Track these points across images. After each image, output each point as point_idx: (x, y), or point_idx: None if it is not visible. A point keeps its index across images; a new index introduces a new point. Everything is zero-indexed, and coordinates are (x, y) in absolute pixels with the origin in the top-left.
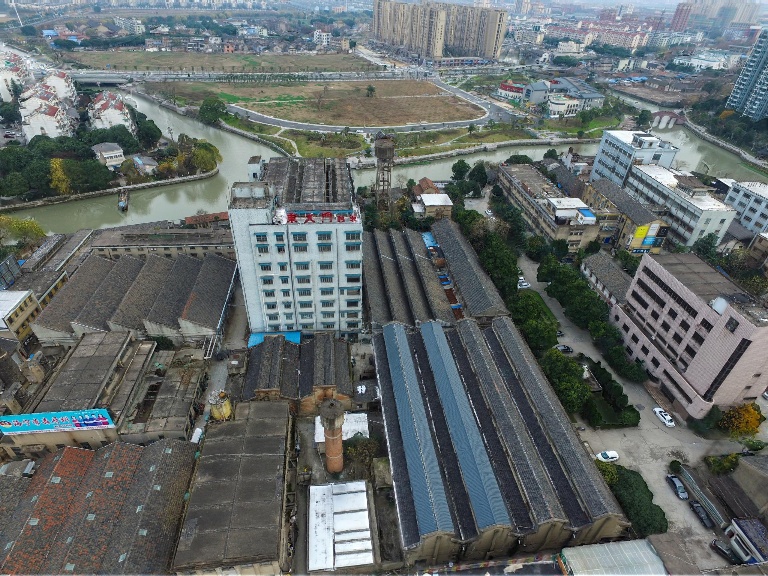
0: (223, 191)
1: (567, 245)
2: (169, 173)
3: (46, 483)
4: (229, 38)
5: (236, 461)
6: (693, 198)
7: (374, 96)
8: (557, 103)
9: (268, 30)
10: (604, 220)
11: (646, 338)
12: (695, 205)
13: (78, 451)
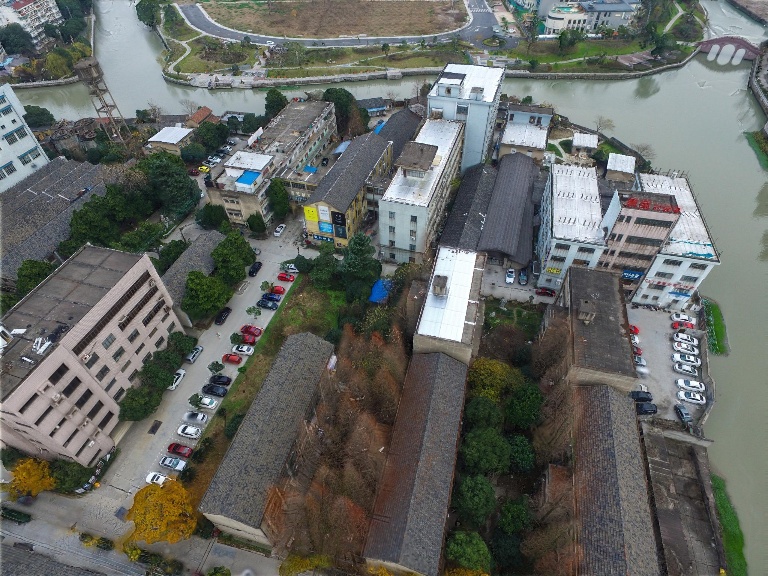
0: None
1: (219, 214)
2: (31, 76)
3: None
4: None
5: None
6: (406, 178)
7: None
8: (553, 17)
9: None
10: (305, 190)
11: None
12: (386, 189)
13: None
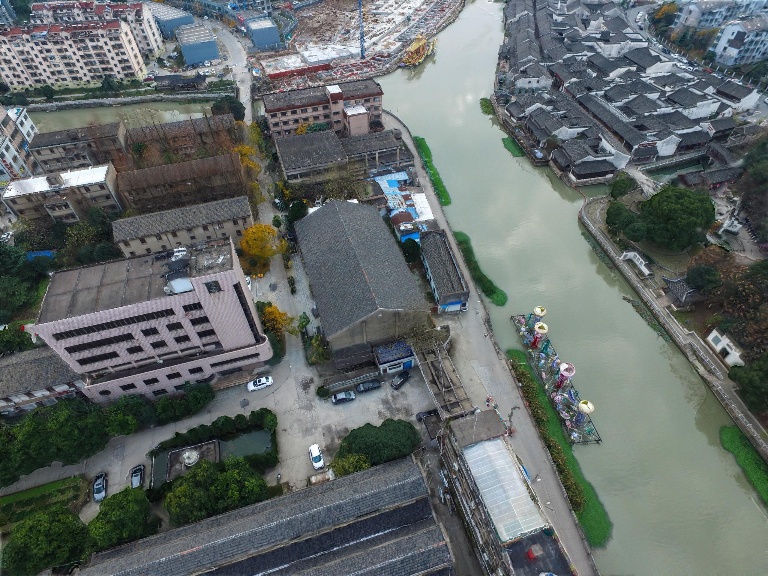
0: None
1: None
2: None
3: None
4: None
5: None
6: None
7: None
8: None
9: None
10: None
11: (160, 370)
12: None
13: None
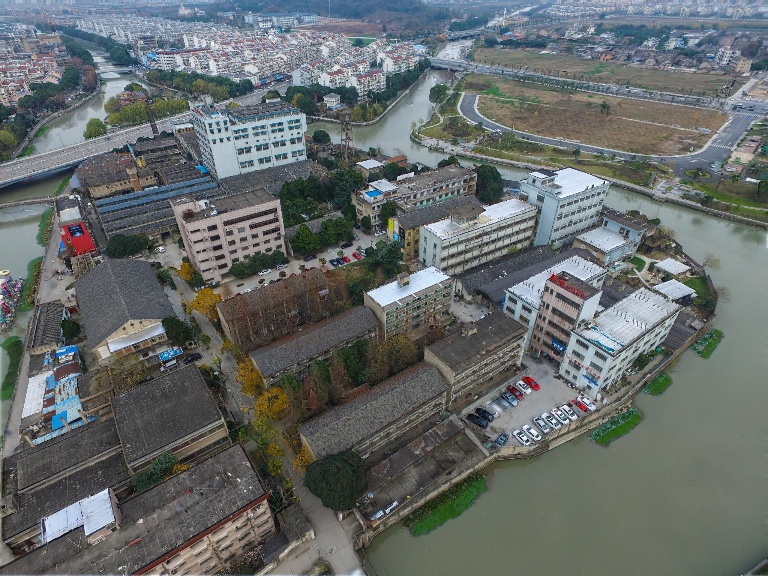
0: (367, 138)
1: (351, 210)
2: None
3: (116, 161)
4: (621, 48)
5: (122, 173)
6: (452, 222)
7: (606, 114)
8: None
9: (677, 43)
10: None
11: None
12: None
13: (130, 161)
